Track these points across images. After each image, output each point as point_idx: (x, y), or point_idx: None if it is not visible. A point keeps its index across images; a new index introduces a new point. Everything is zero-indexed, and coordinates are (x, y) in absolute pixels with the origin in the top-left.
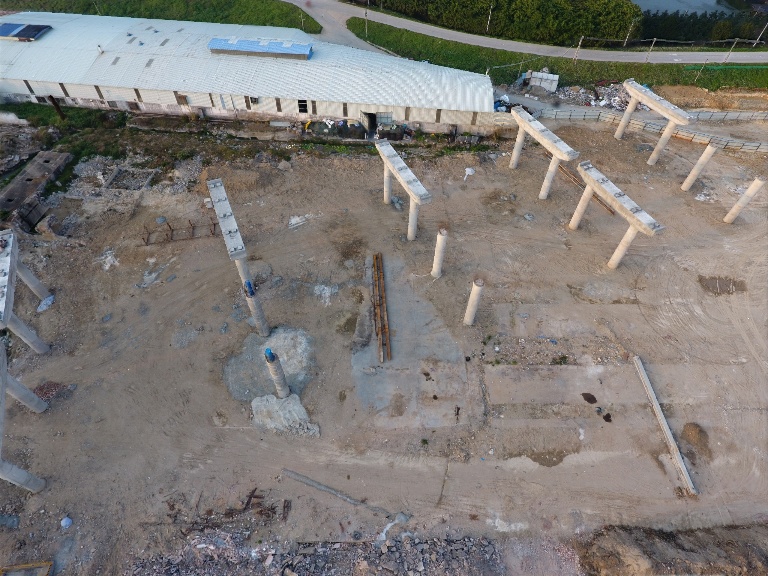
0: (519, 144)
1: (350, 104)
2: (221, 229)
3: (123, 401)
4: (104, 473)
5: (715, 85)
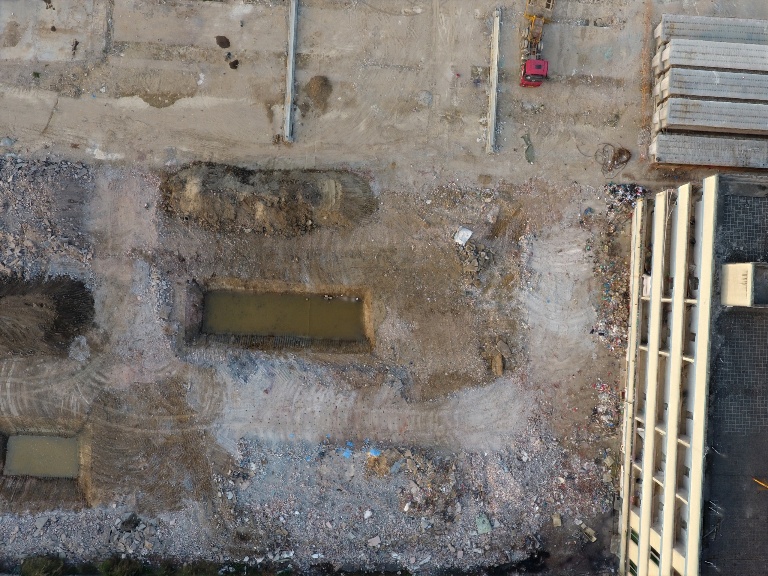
0: None
1: None
2: None
3: None
4: None
5: None
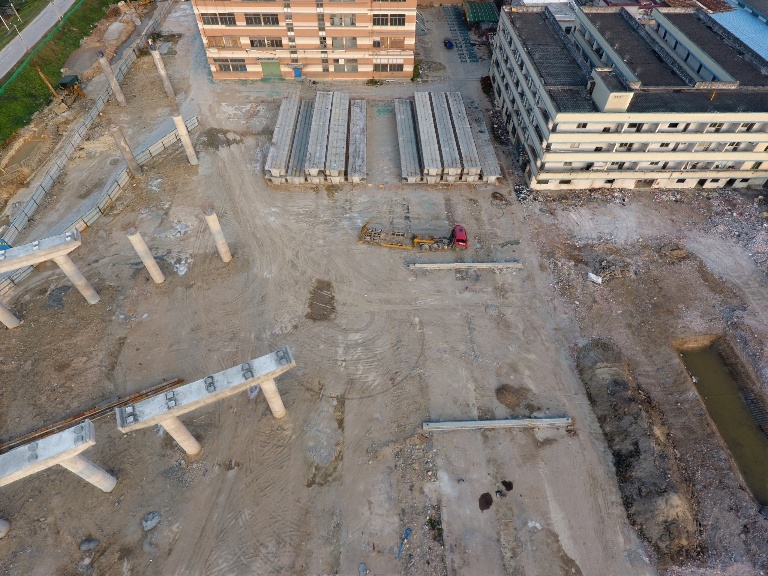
0: None
1: None
2: None
3: None
4: None
5: None
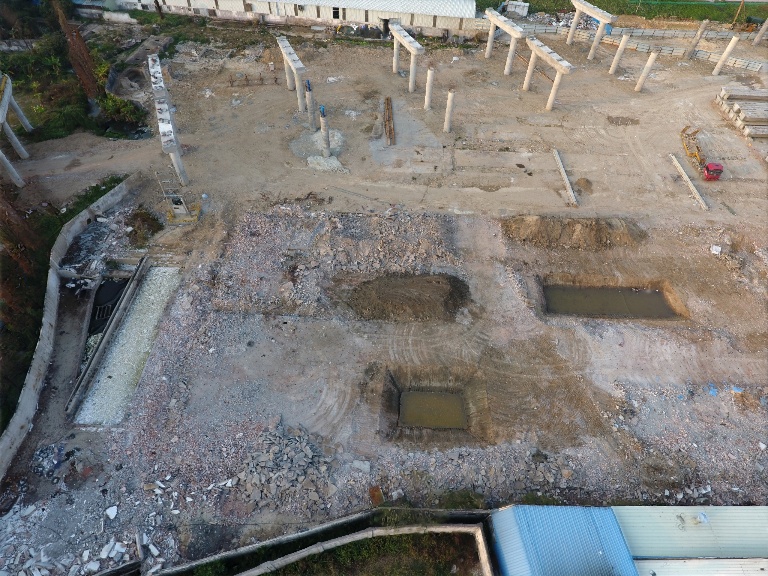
0: (491, 36)
1: (370, 11)
2: (288, 59)
3: (228, 154)
4: (222, 181)
5: (652, 15)
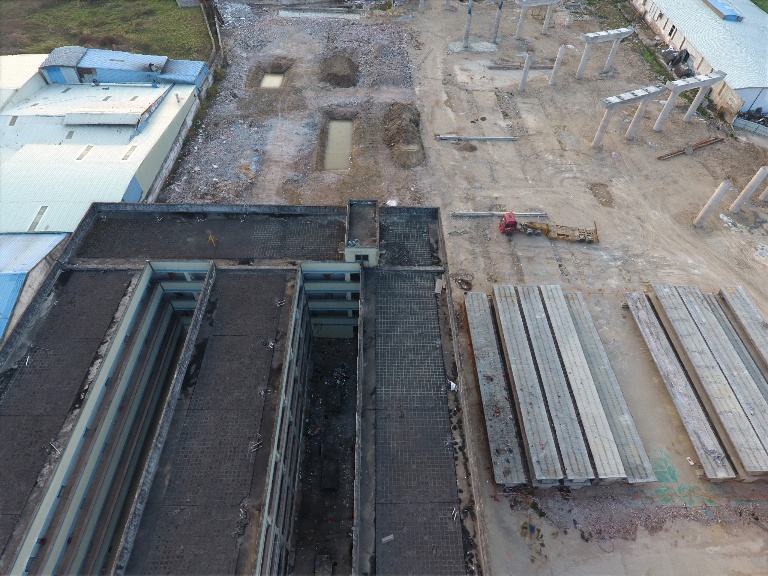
0: None
1: (686, 40)
2: None
3: (453, 20)
4: (427, 20)
5: None
